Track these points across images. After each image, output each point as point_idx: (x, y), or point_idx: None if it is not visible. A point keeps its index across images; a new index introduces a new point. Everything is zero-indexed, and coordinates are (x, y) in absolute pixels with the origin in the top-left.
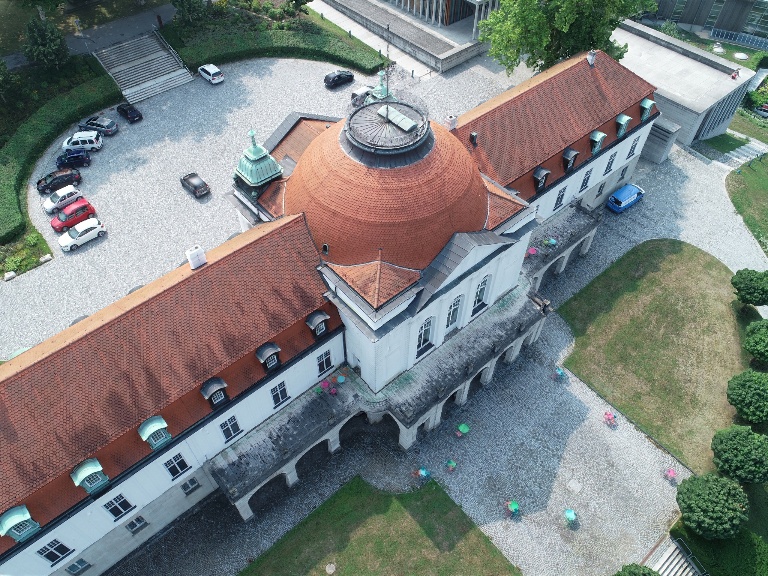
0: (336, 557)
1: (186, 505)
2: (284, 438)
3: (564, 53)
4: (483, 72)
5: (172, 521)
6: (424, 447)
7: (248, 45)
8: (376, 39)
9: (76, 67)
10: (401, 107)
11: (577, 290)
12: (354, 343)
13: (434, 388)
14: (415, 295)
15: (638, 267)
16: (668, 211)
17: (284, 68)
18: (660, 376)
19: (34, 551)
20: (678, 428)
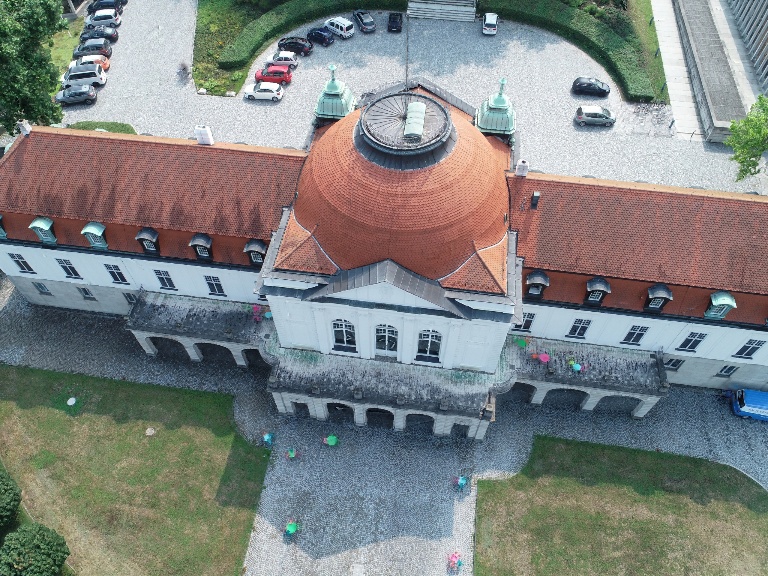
0: (161, 429)
1: (130, 311)
2: (196, 319)
3: None
4: None
5: (118, 314)
6: (295, 424)
7: (546, 14)
8: (681, 71)
9: None
10: (438, 114)
11: (582, 439)
12: None
13: (320, 383)
14: (317, 284)
15: (680, 479)
16: None
17: (558, 51)
18: None
19: (6, 251)
20: None
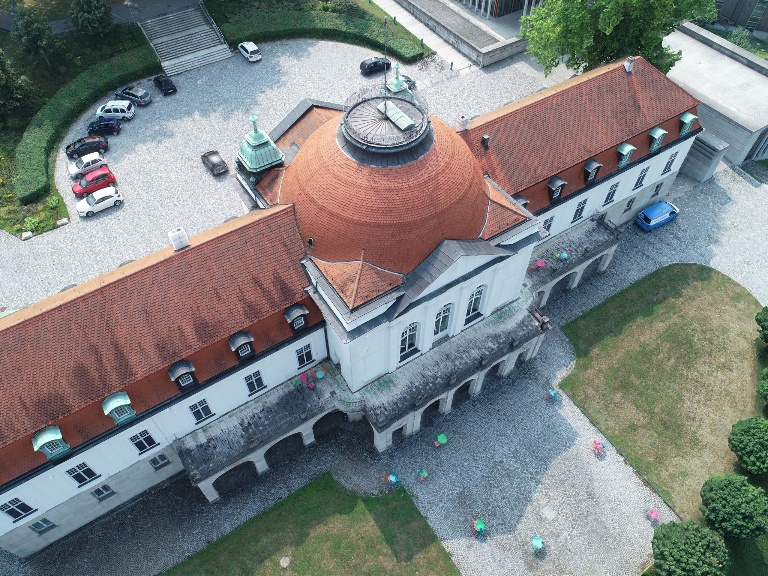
0: (292, 551)
1: (156, 479)
2: (255, 427)
3: (608, 56)
4: (526, 69)
5: (141, 493)
6: (399, 452)
7: (290, 25)
8: (421, 27)
9: (120, 36)
10: (404, 104)
11: (588, 308)
12: (334, 340)
13: (413, 395)
14: (395, 300)
15: (658, 291)
16: (702, 234)
17: (323, 51)
18: (661, 410)
19: None
20: (671, 467)
